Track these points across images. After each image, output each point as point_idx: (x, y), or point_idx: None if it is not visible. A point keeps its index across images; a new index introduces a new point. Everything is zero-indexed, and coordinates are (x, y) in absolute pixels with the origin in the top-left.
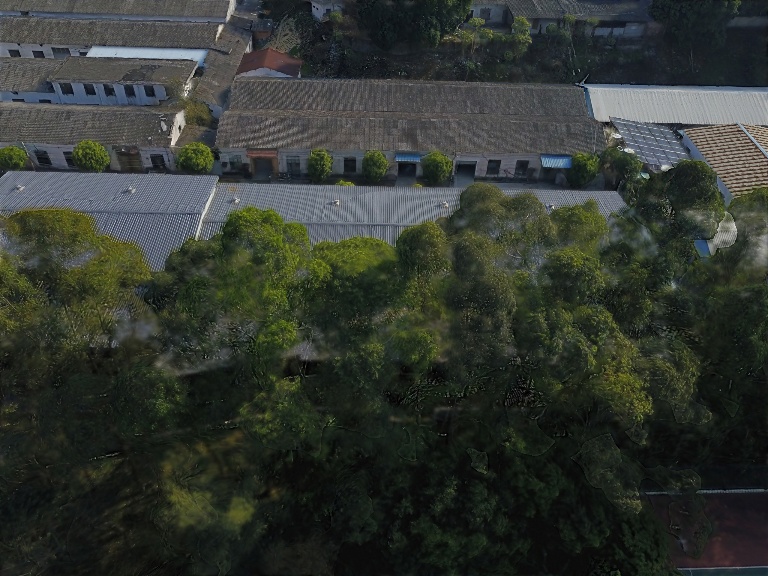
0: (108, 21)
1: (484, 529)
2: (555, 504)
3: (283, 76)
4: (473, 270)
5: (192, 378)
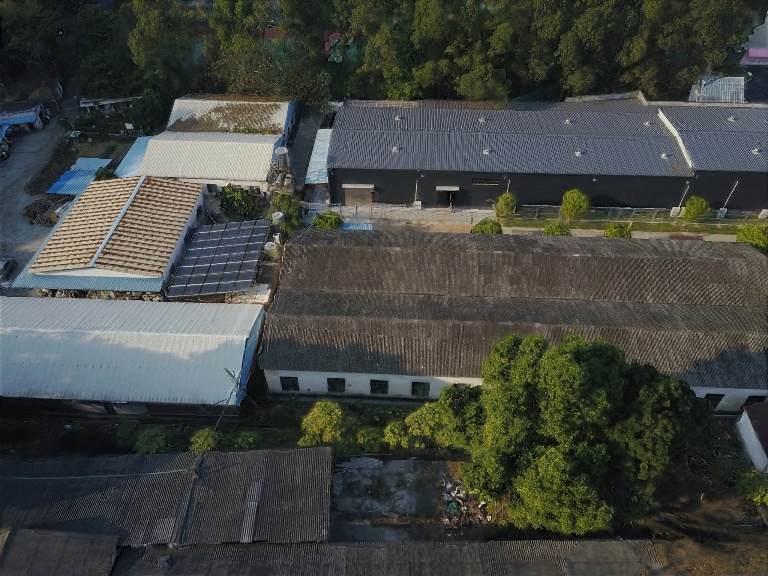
0: None
1: None
2: None
3: None
4: None
5: None
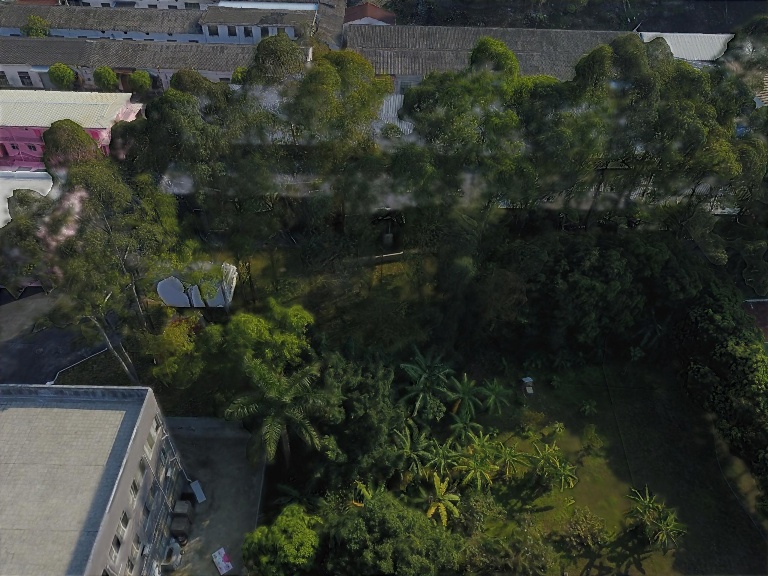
0: None
1: (618, 280)
2: (664, 269)
3: None
4: (638, 69)
5: (439, 159)
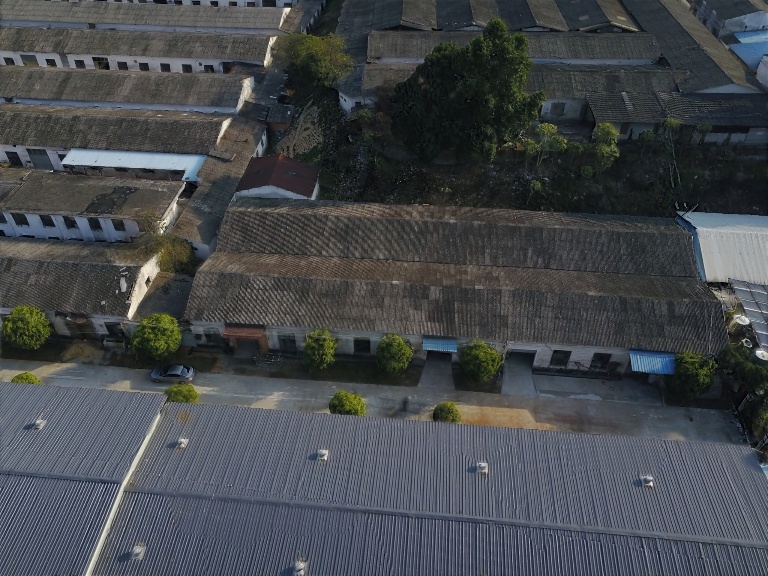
0: (94, 116)
1: None
2: None
3: (293, 195)
4: None
5: None
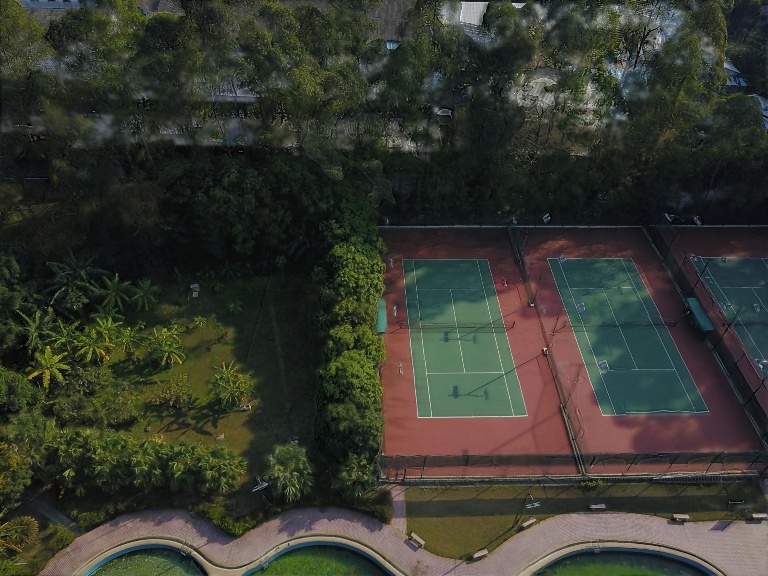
0: None
1: (255, 194)
2: (303, 187)
3: None
4: (209, 2)
5: (73, 84)
